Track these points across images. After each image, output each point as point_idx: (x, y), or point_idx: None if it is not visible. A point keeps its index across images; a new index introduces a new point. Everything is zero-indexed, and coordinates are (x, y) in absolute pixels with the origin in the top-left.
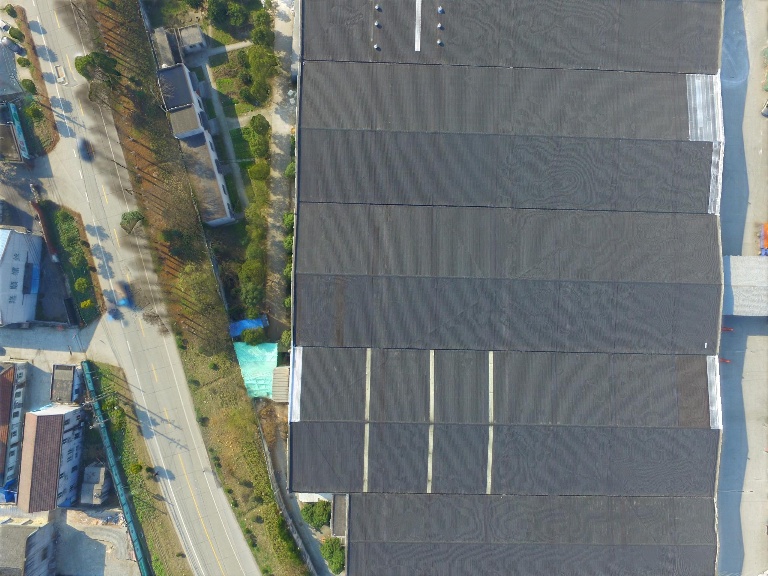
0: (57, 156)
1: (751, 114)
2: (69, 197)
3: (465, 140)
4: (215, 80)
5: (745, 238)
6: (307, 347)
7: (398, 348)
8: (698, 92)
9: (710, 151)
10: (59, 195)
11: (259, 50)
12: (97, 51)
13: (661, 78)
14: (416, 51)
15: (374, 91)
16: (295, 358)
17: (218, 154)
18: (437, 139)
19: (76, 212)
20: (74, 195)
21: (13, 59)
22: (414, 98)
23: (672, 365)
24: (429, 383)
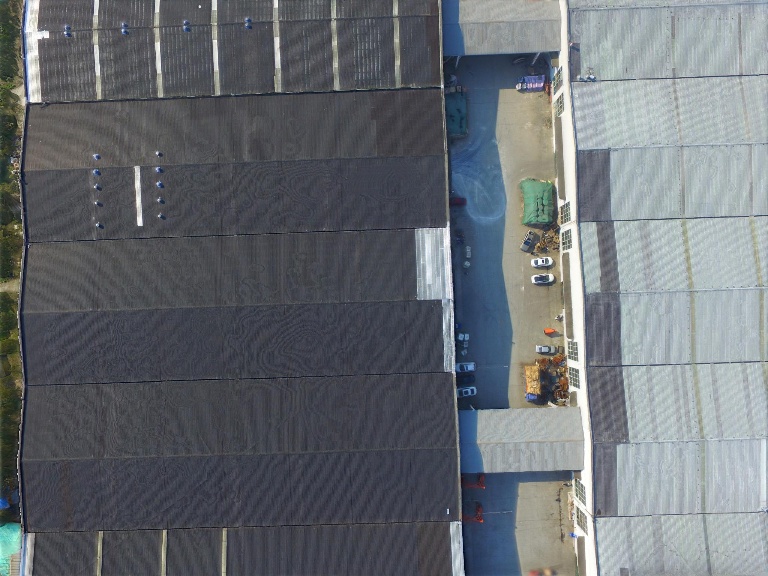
0: None
1: (510, 250)
2: None
3: (187, 314)
4: None
5: (511, 380)
6: (39, 533)
7: (130, 530)
8: (427, 247)
9: (440, 309)
10: None
11: None
12: None
13: (389, 235)
14: (139, 226)
15: (97, 270)
16: (27, 545)
17: None
18: (159, 315)
19: None
20: None
21: None
22: (137, 274)
23: (413, 534)
24: (161, 566)
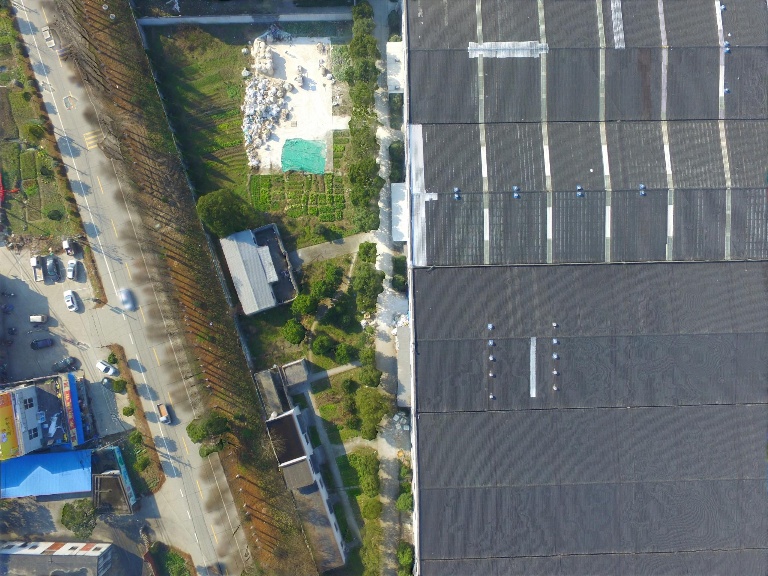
0: (164, 496)
1: None
2: (178, 538)
3: (587, 490)
4: (318, 407)
5: None
6: None
7: None
8: None
9: None
10: (168, 536)
11: (372, 406)
12: (199, 388)
13: None
14: (531, 397)
15: (492, 443)
16: None
17: (325, 483)
18: (558, 491)
19: (186, 553)
20: (183, 536)
21: (114, 400)
22: (532, 447)
23: None
24: None
